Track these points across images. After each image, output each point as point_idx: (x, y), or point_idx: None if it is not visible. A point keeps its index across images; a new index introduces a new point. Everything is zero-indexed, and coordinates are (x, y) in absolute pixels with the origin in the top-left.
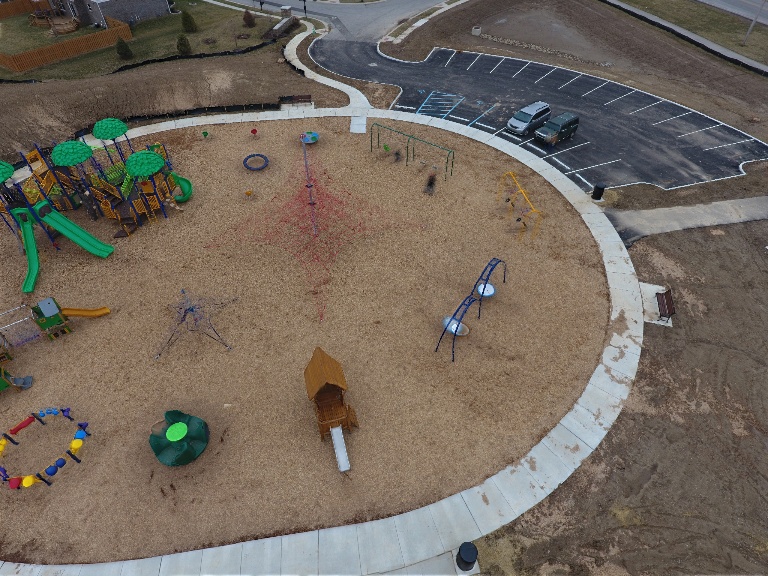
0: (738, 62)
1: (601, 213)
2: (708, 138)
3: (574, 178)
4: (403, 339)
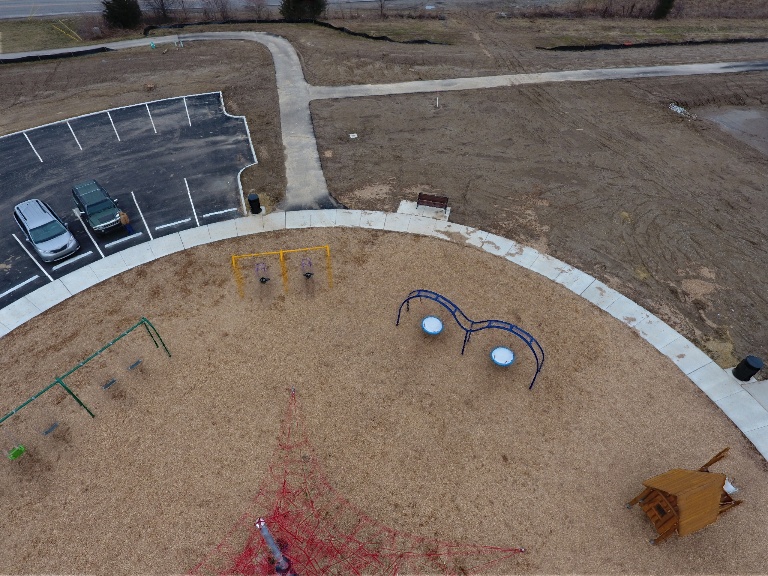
0: (34, 58)
1: (287, 213)
2: (169, 118)
3: (211, 220)
4: (524, 424)
